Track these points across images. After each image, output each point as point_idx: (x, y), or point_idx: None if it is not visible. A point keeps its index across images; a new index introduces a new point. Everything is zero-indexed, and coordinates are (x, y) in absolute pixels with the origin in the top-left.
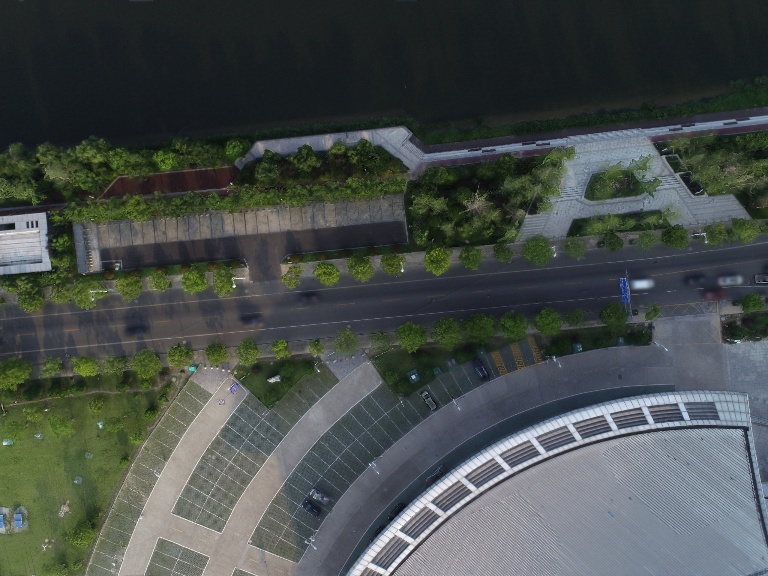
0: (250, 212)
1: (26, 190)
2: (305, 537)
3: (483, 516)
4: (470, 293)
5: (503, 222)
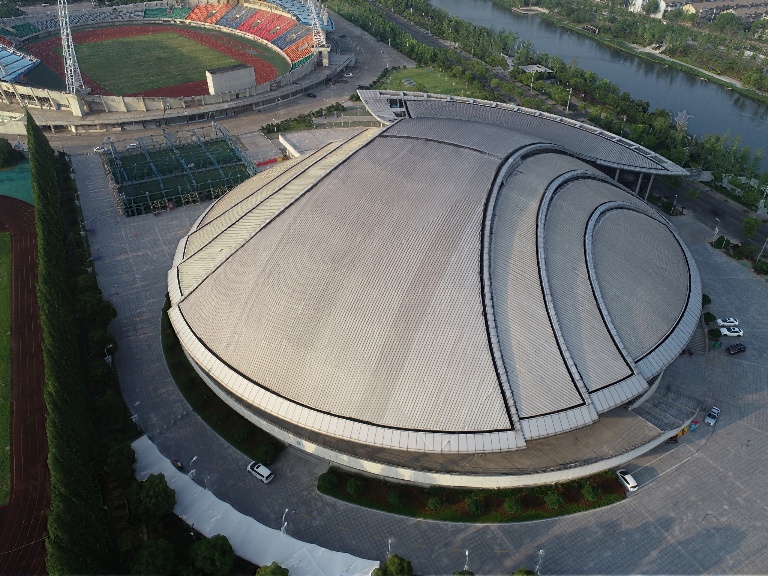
0: None
1: None
2: None
3: None
4: None
5: None
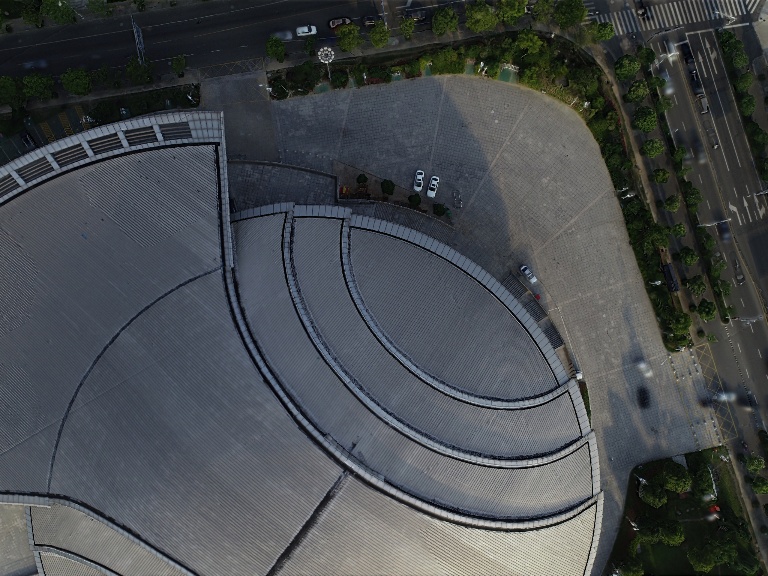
0: None
1: None
2: None
3: None
4: (15, 66)
5: None
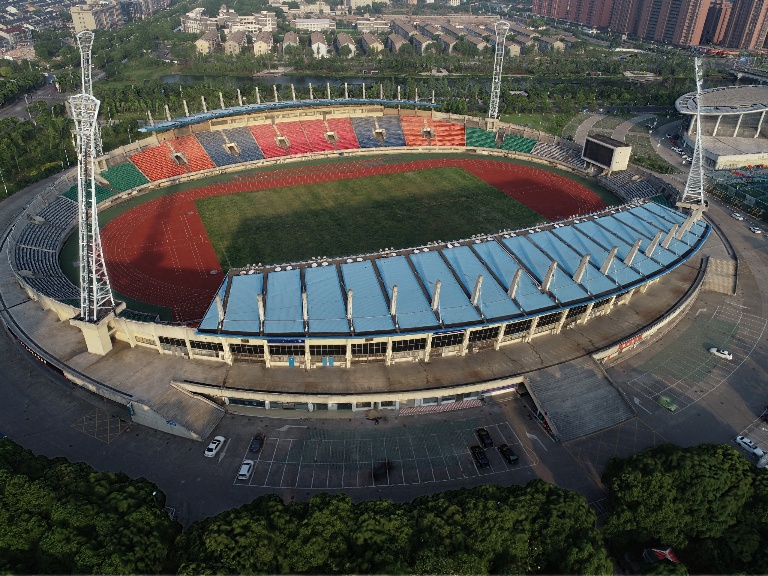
0: None
1: (518, 86)
2: None
3: None
4: None
5: None
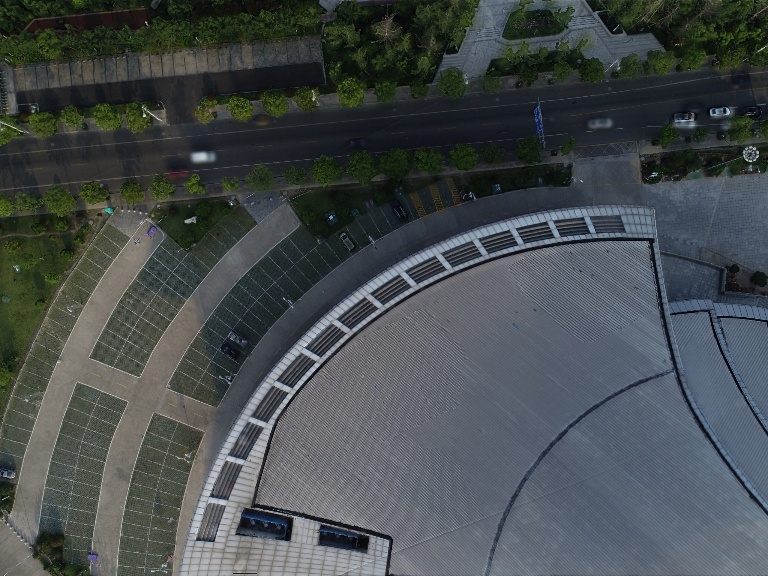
0: (167, 54)
1: None
2: (224, 381)
3: (389, 332)
4: (388, 134)
5: (417, 56)
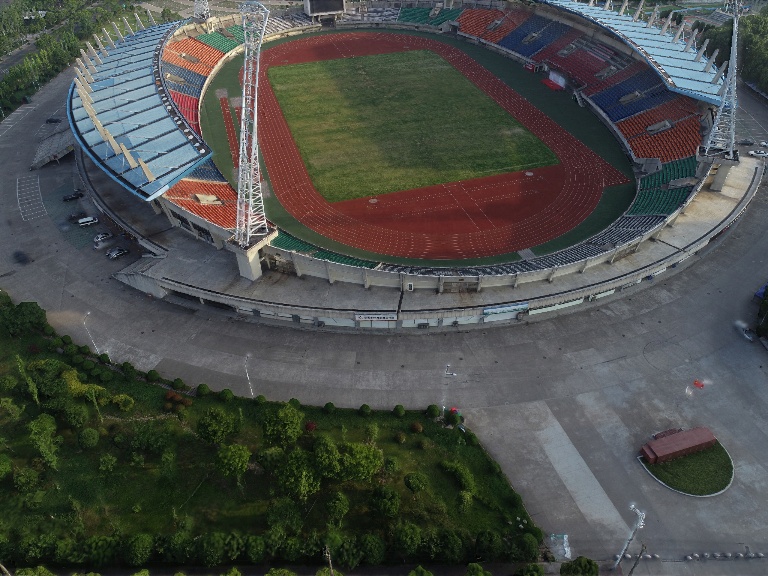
0: None
1: None
2: None
3: None
4: None
5: None
